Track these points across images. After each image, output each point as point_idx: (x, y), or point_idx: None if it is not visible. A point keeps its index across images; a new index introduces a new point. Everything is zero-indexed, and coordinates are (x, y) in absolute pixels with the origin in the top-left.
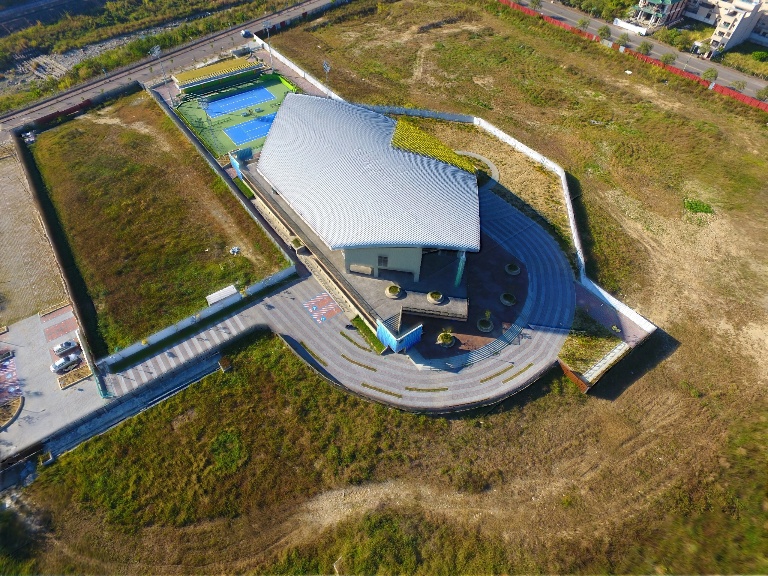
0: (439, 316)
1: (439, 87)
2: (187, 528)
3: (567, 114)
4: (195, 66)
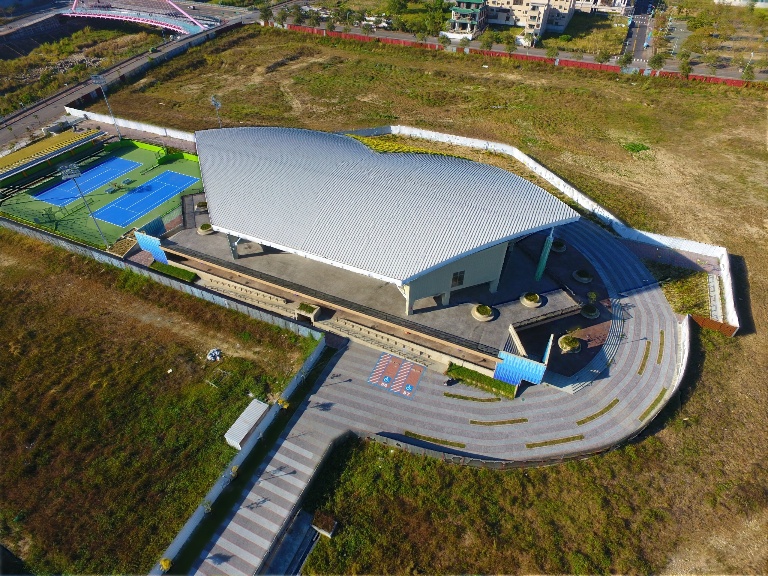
0: (552, 318)
1: (329, 112)
2: None
3: (467, 107)
4: None
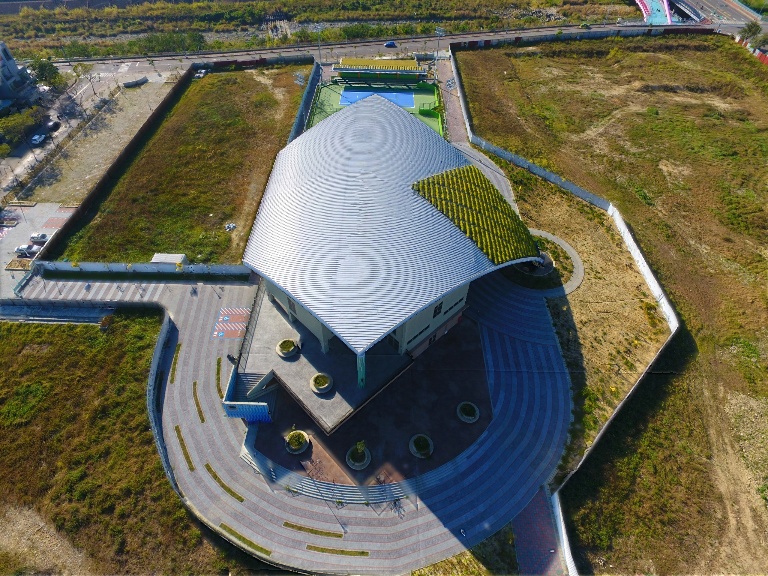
0: (303, 407)
1: (603, 155)
2: None
3: None
4: (374, 58)
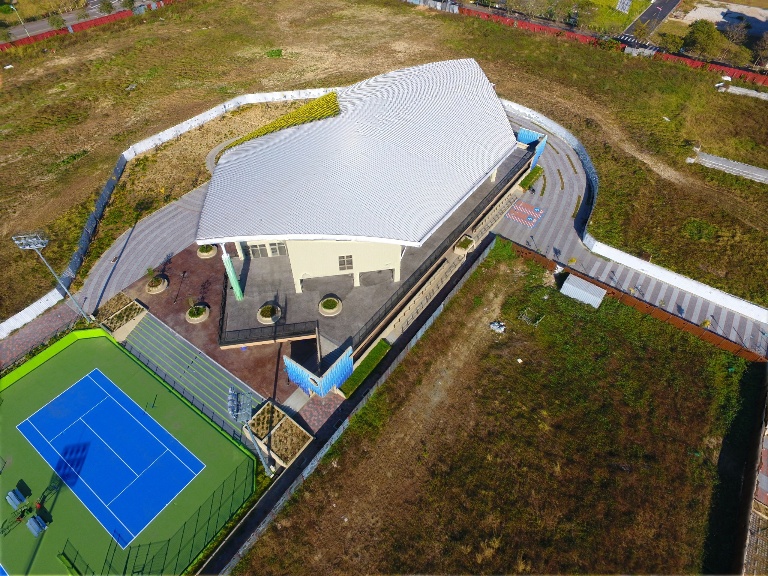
0: None
1: None
2: (762, 231)
3: (109, 102)
4: None
